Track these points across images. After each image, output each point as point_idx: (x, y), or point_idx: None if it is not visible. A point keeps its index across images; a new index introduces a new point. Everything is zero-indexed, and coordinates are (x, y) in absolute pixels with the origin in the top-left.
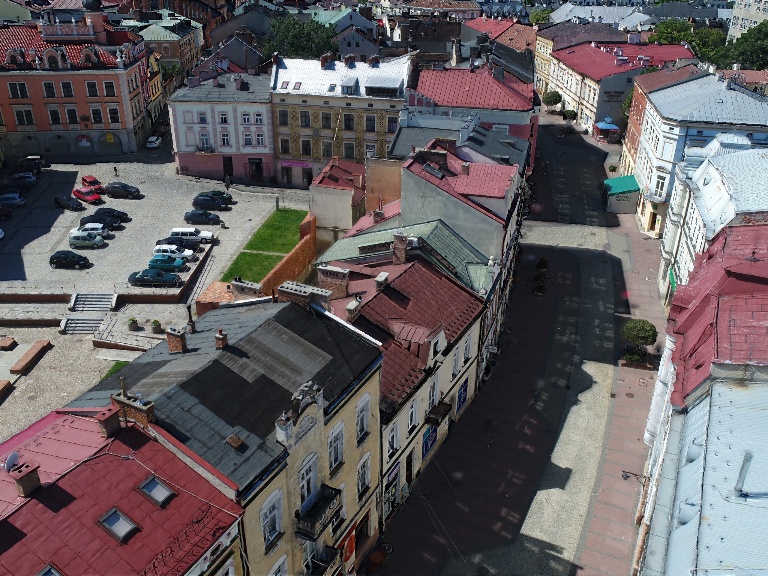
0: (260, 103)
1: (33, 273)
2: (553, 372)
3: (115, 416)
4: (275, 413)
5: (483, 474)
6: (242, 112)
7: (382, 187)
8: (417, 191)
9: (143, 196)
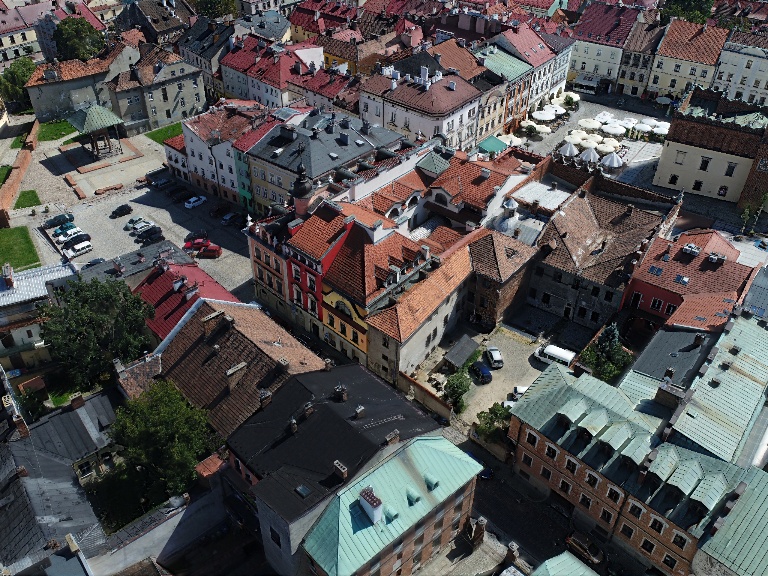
0: None
1: (134, 204)
2: None
3: None
4: None
5: None
6: None
7: None
8: None
9: None
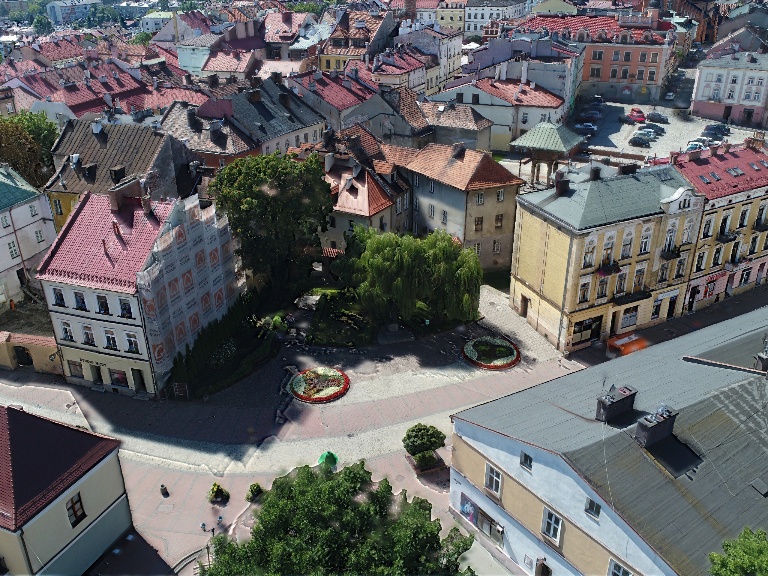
0: (765, 71)
1: (620, 146)
2: None
3: (750, 142)
4: None
5: None
6: (749, 76)
7: None
8: None
9: (669, 123)
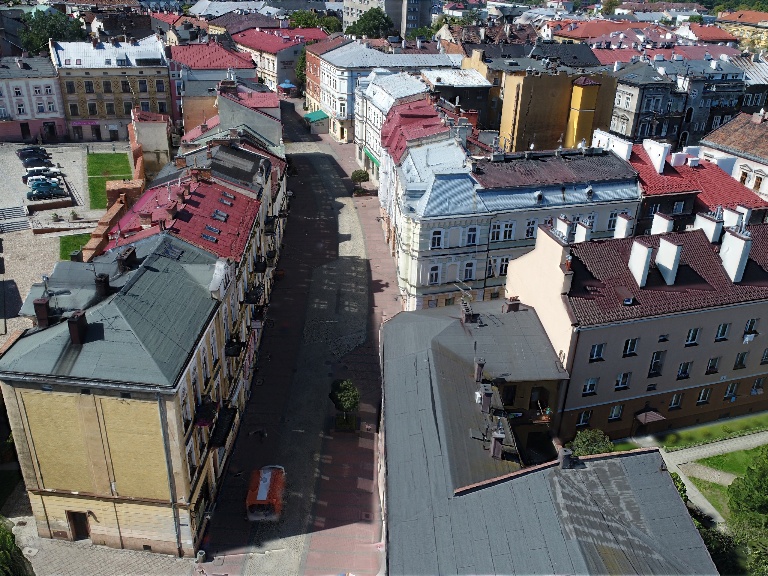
0: (49, 77)
1: None
2: (322, 204)
3: None
4: (249, 177)
5: (310, 243)
6: (34, 85)
7: (195, 114)
8: (228, 108)
9: None
